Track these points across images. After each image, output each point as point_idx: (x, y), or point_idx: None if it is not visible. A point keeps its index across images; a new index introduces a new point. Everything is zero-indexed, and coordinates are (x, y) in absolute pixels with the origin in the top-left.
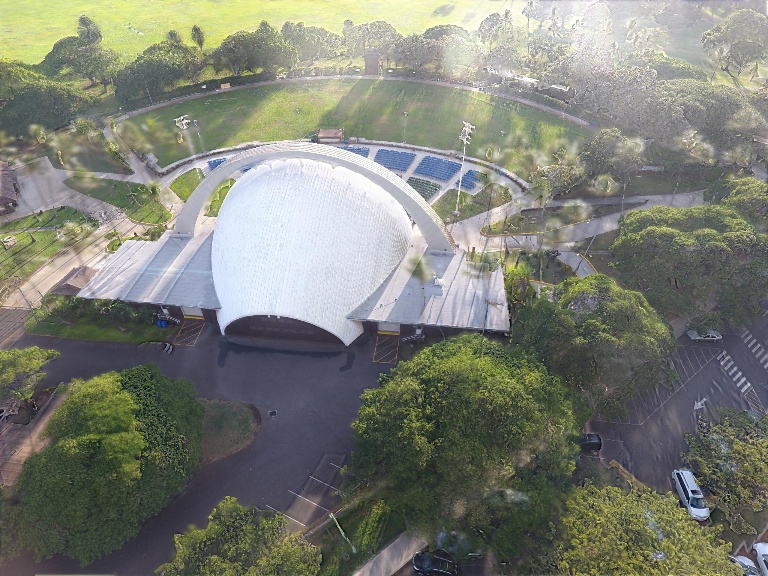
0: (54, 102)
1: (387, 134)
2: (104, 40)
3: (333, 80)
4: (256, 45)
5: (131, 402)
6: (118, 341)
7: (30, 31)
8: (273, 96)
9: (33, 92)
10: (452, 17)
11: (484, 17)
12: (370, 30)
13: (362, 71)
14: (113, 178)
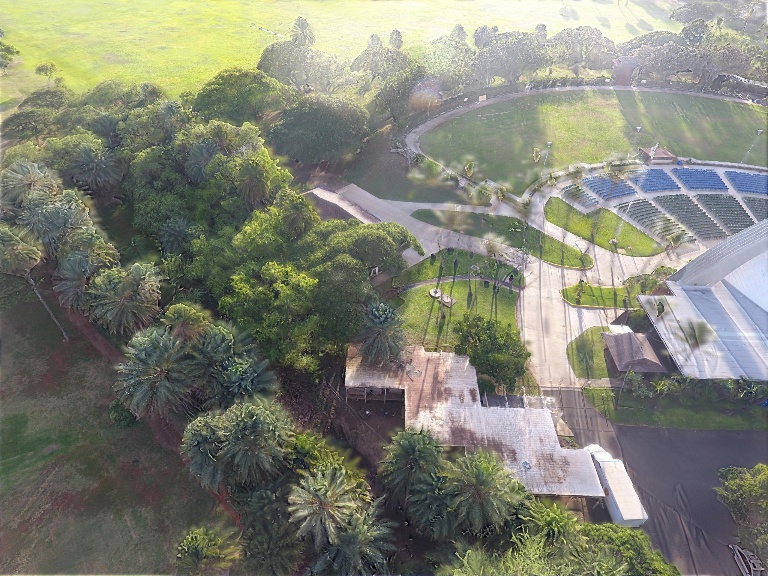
0: (347, 120)
1: (713, 153)
2: (248, 42)
3: (588, 91)
4: (524, 53)
5: None
6: (737, 429)
7: (149, 31)
8: (543, 110)
9: (325, 108)
10: (587, 21)
11: (619, 21)
12: (582, 36)
13: (612, 81)
14: (474, 211)
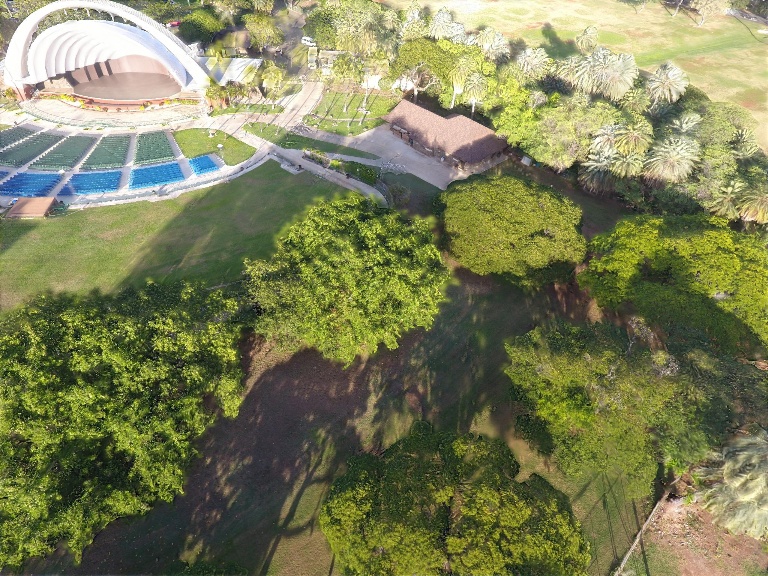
0: None
1: None
2: None
3: None
4: None
5: (199, 15)
6: None
7: None
8: None
9: None
10: None
11: None
12: None
13: None
14: None
